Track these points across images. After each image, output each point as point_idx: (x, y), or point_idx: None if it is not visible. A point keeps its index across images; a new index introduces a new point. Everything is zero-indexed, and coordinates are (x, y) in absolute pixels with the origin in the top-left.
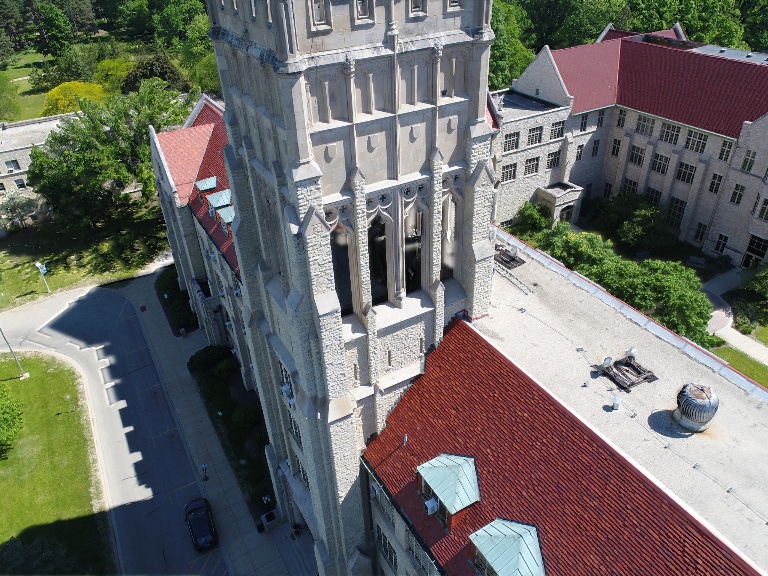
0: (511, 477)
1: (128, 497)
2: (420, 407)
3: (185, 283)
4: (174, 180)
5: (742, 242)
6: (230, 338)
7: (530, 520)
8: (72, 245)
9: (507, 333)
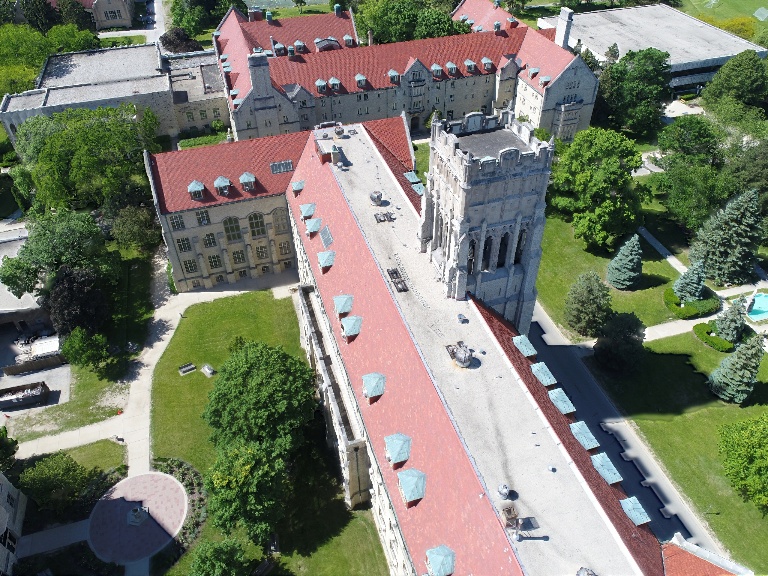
0: None
1: (616, 427)
2: None
3: None
4: (689, 555)
5: None
6: None
7: None
8: None
9: None
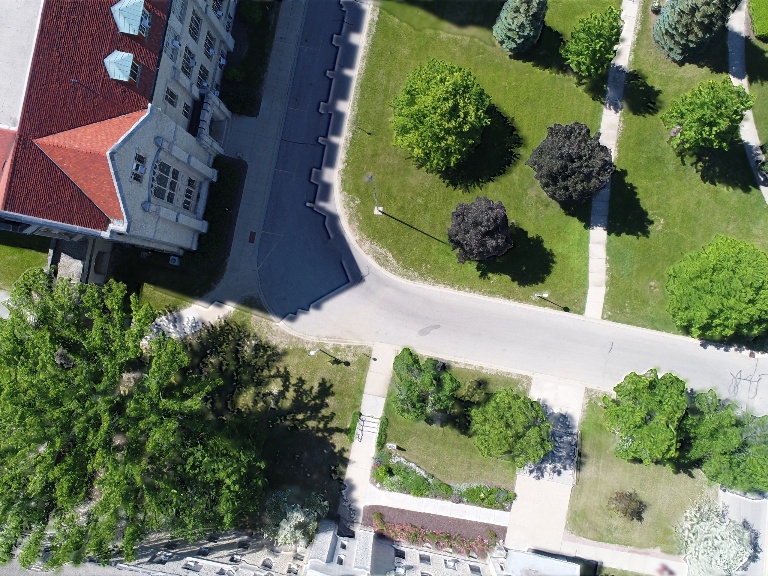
0: None
1: (356, 7)
2: None
3: None
4: None
5: None
6: None
7: None
8: None
9: None
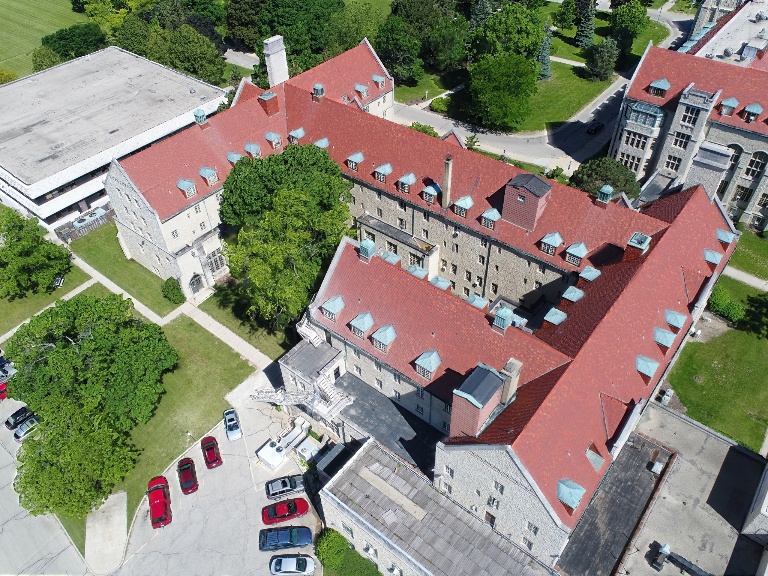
0: None
1: None
2: None
3: None
4: None
5: None
6: None
7: None
8: None
9: (756, 6)
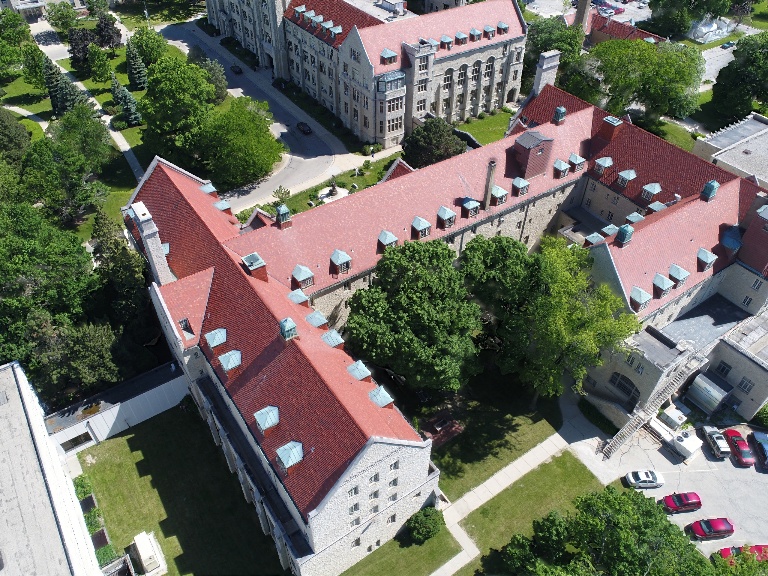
0: (311, 4)
1: None
2: (295, 1)
3: (212, 19)
4: None
5: (442, 8)
6: (235, 33)
7: (313, 9)
8: (150, 11)
9: None
